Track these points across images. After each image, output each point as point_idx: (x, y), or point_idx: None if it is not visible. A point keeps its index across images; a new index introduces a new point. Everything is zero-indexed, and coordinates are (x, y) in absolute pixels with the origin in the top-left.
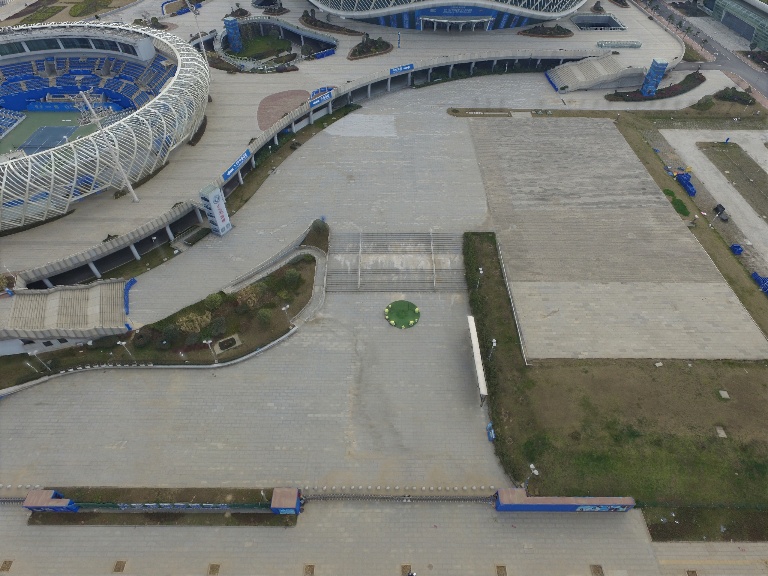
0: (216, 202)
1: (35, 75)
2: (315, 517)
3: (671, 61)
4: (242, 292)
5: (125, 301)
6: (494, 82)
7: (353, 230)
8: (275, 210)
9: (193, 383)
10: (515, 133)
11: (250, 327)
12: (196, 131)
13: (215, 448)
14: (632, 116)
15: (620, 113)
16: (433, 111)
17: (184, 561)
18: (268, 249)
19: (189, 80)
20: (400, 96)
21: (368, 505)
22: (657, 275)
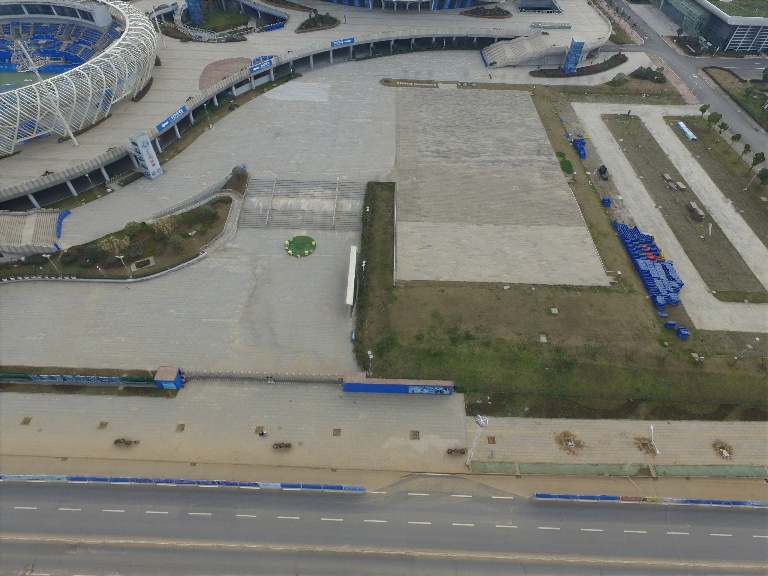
0: (145, 147)
1: (1, 38)
2: (193, 392)
3: (593, 41)
4: (158, 221)
5: (57, 227)
6: (431, 57)
7: (270, 177)
8: (204, 160)
9: (109, 293)
10: (437, 101)
11: (165, 251)
12: (141, 90)
13: (119, 341)
14: (549, 90)
15: (539, 87)
16: (367, 81)
17: (79, 419)
18: (191, 191)
19: (133, 42)
20: (340, 67)
21: (238, 384)
22: (528, 220)
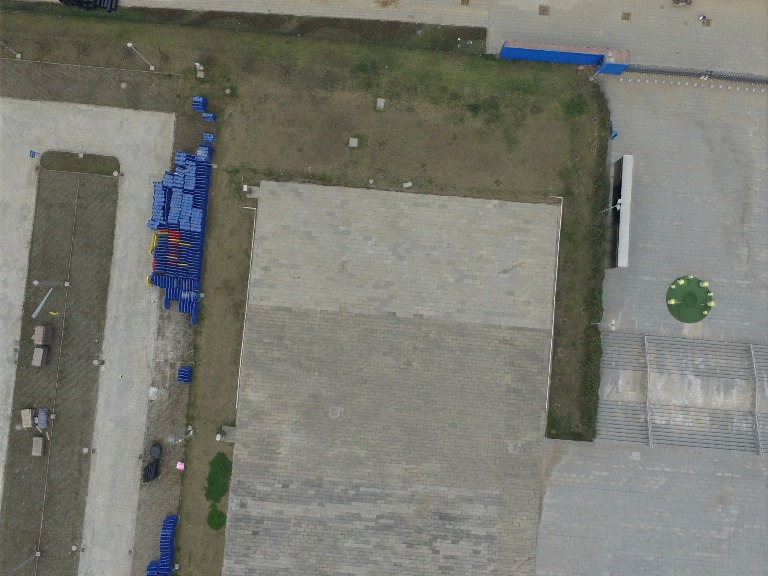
0: None
1: None
2: None
3: None
4: None
5: None
6: None
7: None
8: None
9: None
10: None
11: None
12: None
13: None
14: None
15: None
16: None
17: None
18: None
19: None
20: None
21: None
22: (338, 326)
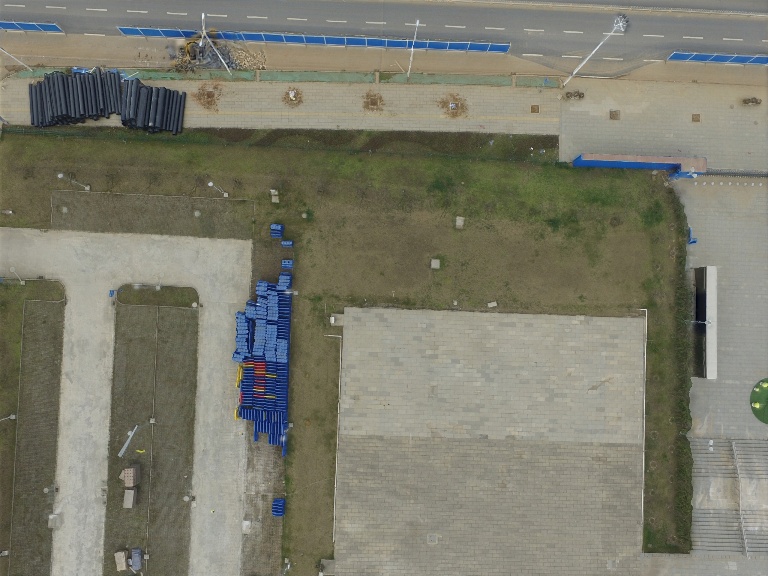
0: None
1: None
2: None
3: None
4: None
5: None
6: None
7: None
8: None
9: None
10: None
11: None
12: None
13: None
14: None
15: None
16: None
17: None
18: None
19: None
20: None
21: None
22: (431, 452)
